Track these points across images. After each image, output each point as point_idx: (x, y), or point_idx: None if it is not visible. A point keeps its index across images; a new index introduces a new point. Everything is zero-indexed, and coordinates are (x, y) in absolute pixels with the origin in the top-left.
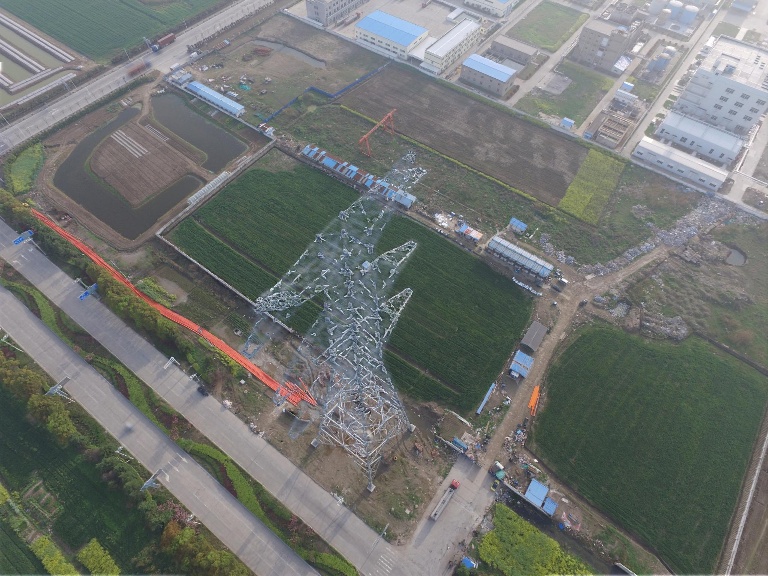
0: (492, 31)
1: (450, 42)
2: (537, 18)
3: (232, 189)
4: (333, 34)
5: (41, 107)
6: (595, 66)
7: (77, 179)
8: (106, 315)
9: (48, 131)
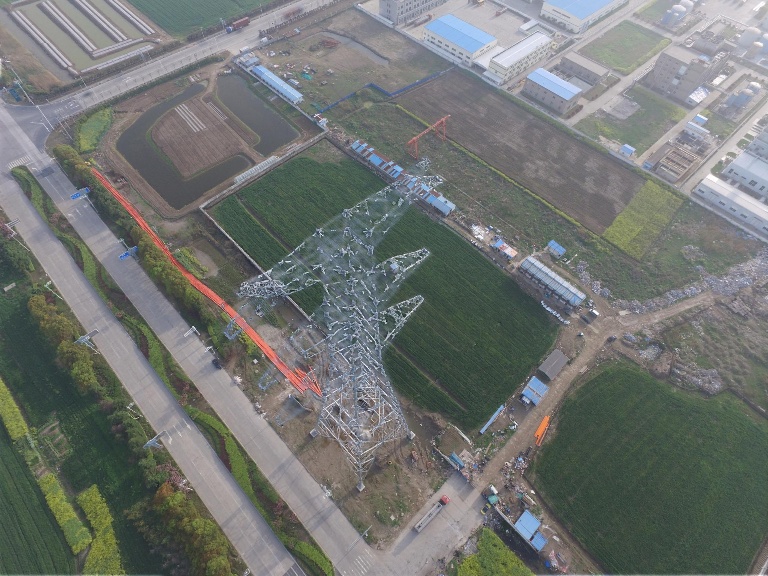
0: (564, 47)
1: (518, 53)
2: (614, 38)
3: (278, 174)
4: (401, 33)
5: (117, 74)
6: (668, 94)
7: (138, 145)
8: (141, 277)
9: (119, 97)
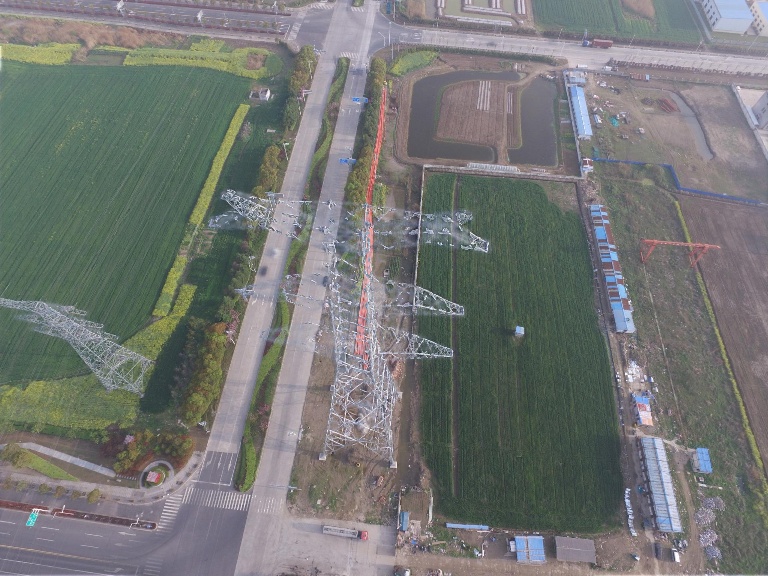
0: None
1: None
2: None
3: (505, 183)
4: (757, 140)
5: (466, 31)
6: None
7: (429, 92)
8: (342, 184)
9: (451, 49)
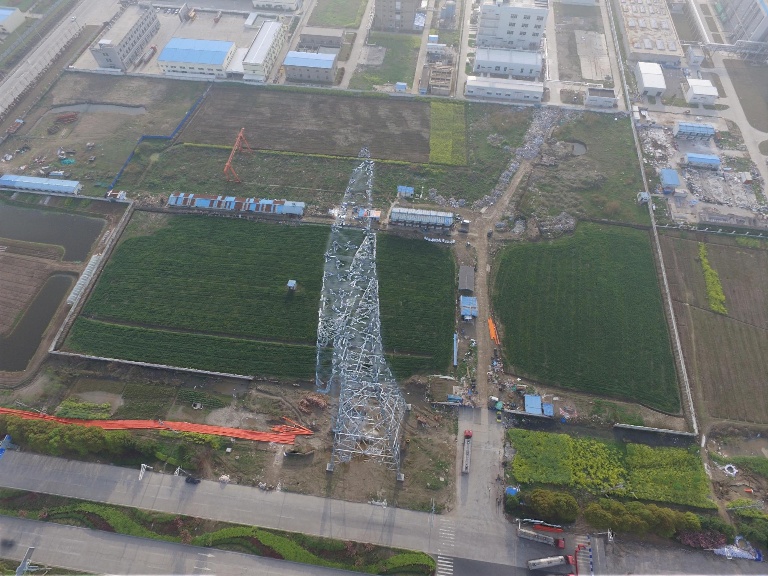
0: (294, 25)
1: (262, 47)
2: (328, 2)
3: (112, 270)
4: (137, 76)
5: None
6: (398, 29)
7: None
8: (37, 462)
9: None
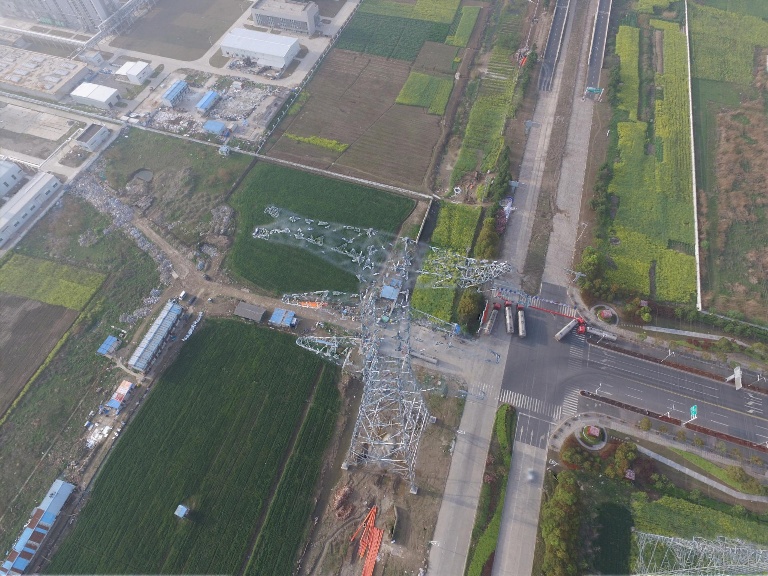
0: None
1: None
2: None
3: None
4: None
5: None
6: None
7: None
8: None
9: None
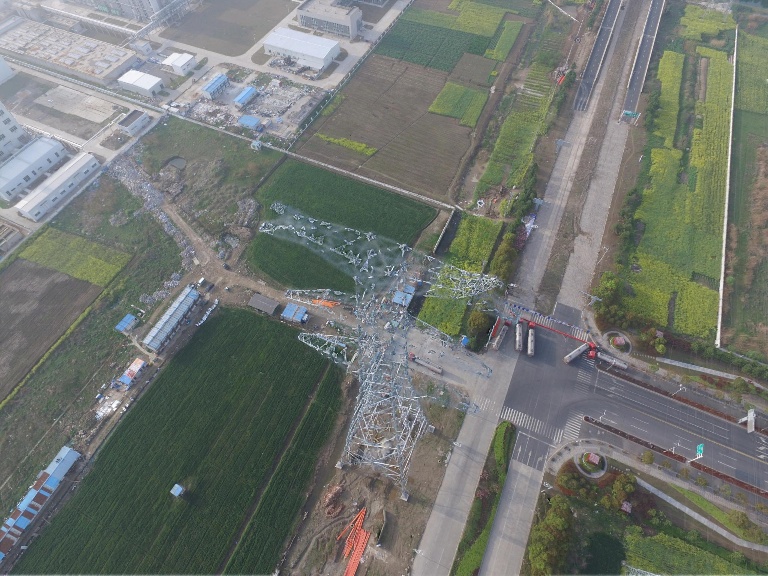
0: None
1: None
2: None
3: None
4: None
5: None
6: None
7: None
8: None
9: None
